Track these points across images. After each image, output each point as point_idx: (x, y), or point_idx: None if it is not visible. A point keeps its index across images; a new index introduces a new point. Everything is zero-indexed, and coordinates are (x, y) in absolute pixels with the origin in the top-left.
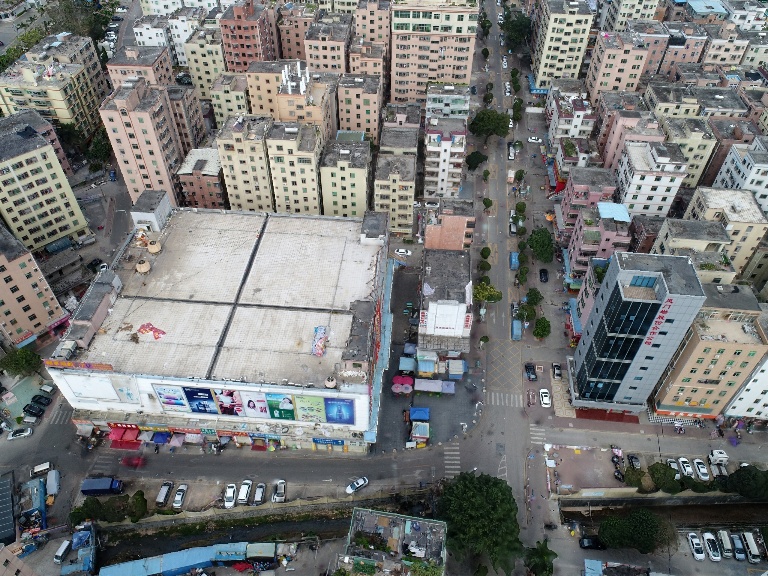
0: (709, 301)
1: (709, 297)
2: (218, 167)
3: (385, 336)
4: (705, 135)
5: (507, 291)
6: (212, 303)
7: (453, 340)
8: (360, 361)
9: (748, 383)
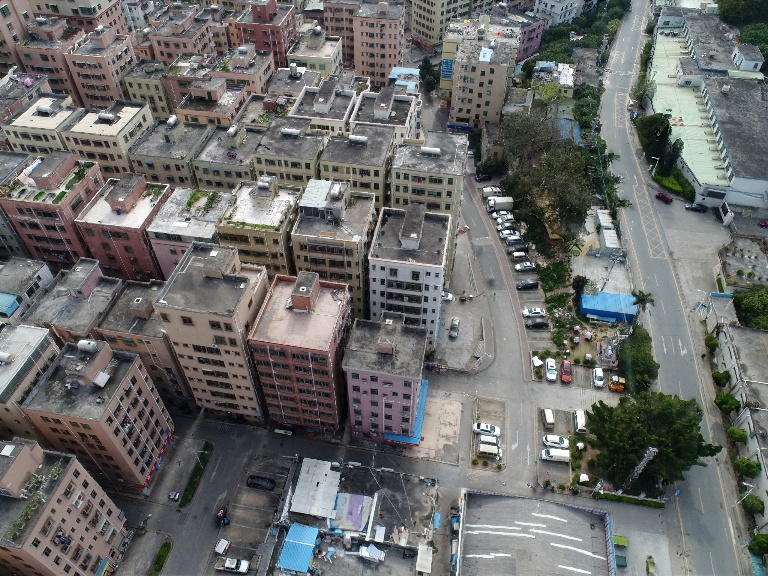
0: None
1: None
2: (311, 1)
3: None
4: None
5: None
6: None
7: None
8: None
9: None
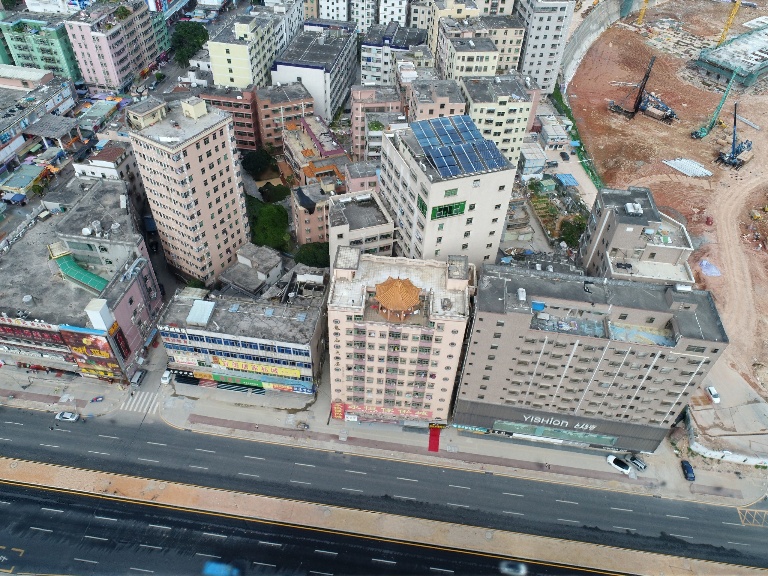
0: None
1: None
2: None
3: (181, 4)
4: None
5: None
6: None
7: (213, 6)
8: None
9: (319, 1)
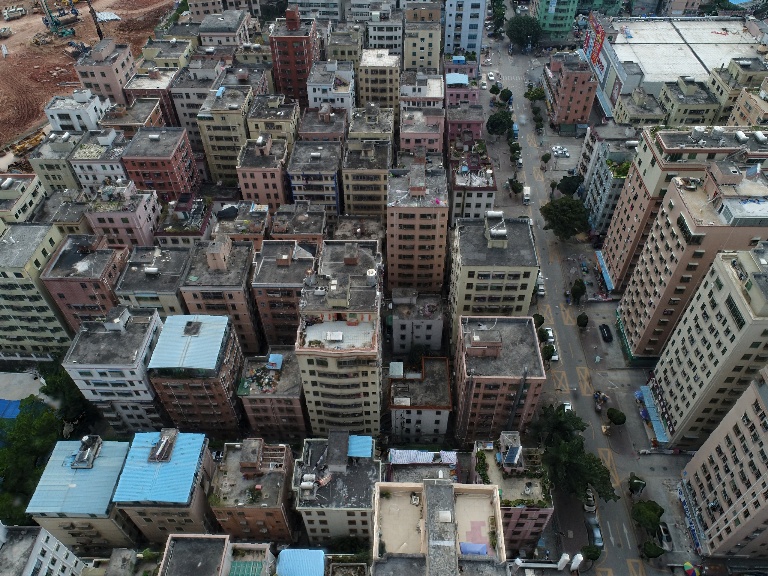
0: (432, 5)
1: (431, 6)
2: None
3: None
4: (360, 116)
5: (517, 119)
6: (701, 43)
7: None
8: (600, 16)
9: None
